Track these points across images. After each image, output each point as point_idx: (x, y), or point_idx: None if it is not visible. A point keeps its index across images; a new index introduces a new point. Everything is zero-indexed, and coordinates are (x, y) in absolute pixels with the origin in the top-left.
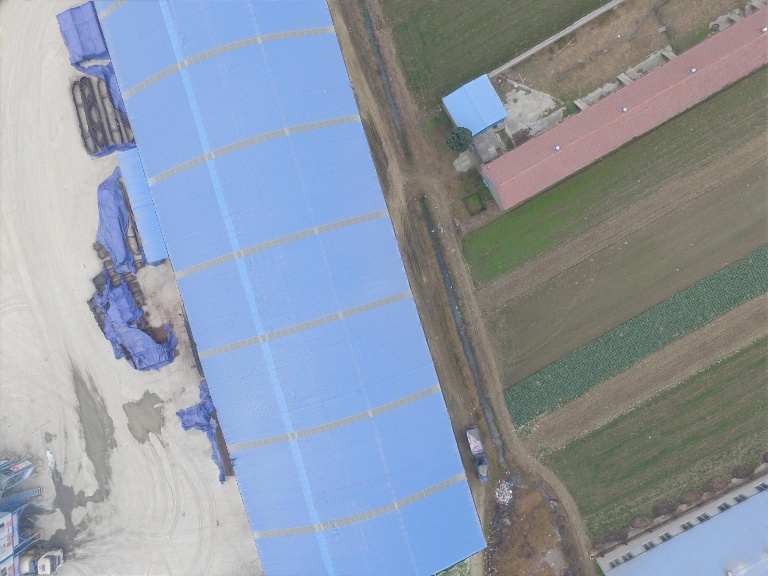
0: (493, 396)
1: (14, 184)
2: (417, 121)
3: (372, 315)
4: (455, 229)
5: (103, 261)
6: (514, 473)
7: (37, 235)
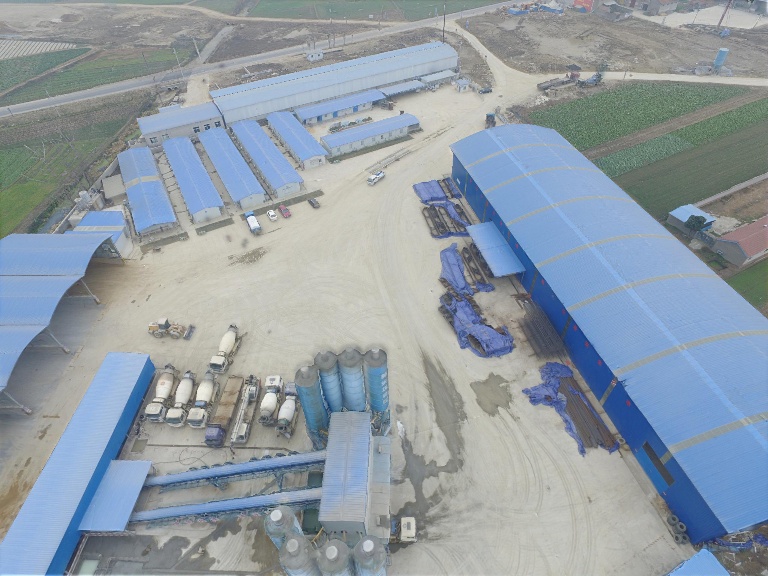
0: None
1: (380, 250)
2: None
3: None
4: None
5: (446, 288)
6: None
7: (395, 274)
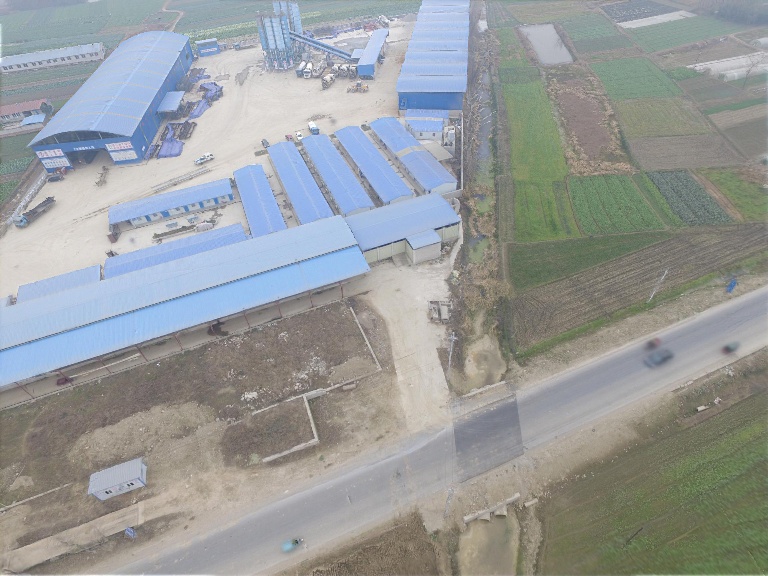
0: None
1: None
2: None
3: None
4: None
5: None
6: None
7: None
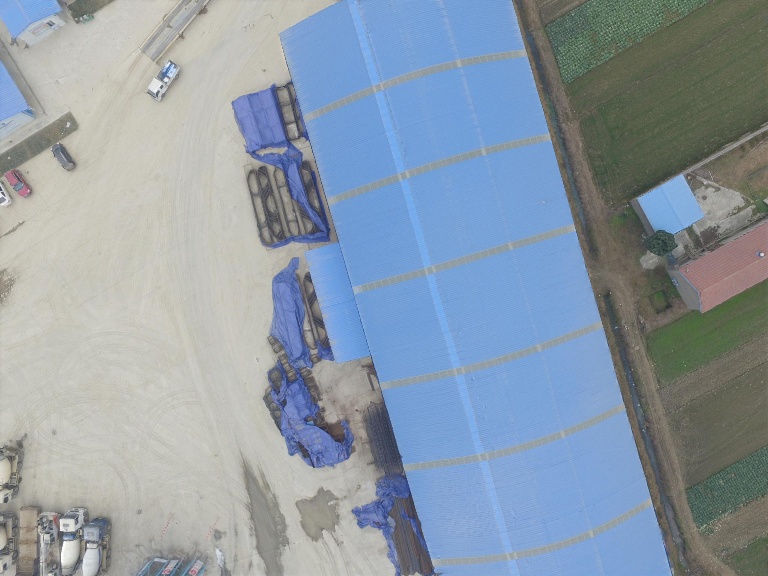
0: (675, 495)
1: (184, 274)
2: (603, 216)
3: (591, 432)
4: (639, 326)
5: (277, 355)
6: (694, 571)
7: (208, 327)
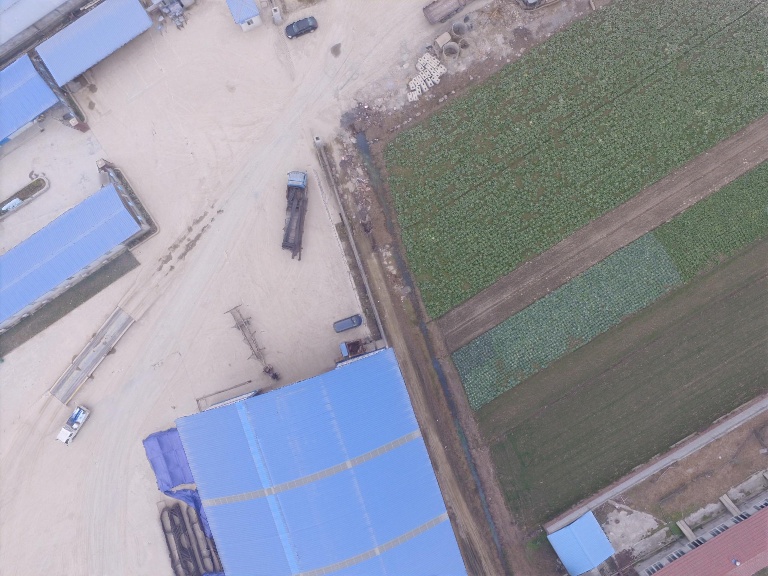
0: None
1: None
2: (517, 541)
3: None
4: None
5: None
6: None
7: None
